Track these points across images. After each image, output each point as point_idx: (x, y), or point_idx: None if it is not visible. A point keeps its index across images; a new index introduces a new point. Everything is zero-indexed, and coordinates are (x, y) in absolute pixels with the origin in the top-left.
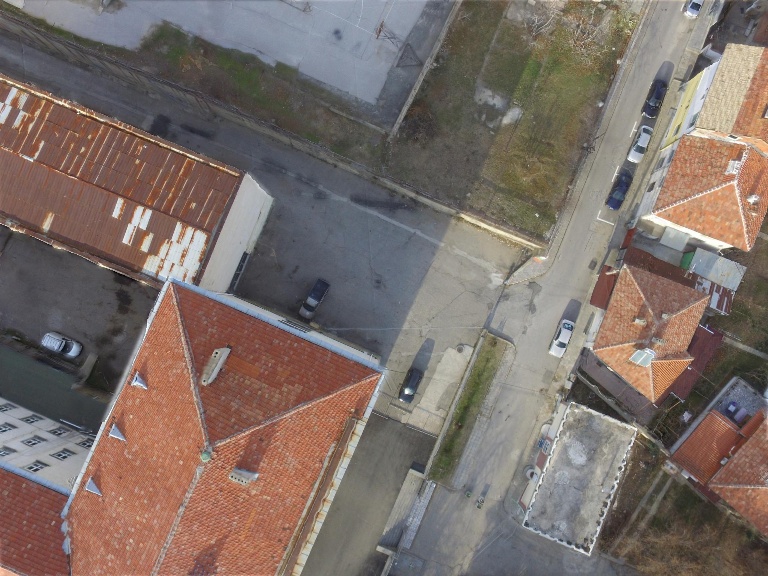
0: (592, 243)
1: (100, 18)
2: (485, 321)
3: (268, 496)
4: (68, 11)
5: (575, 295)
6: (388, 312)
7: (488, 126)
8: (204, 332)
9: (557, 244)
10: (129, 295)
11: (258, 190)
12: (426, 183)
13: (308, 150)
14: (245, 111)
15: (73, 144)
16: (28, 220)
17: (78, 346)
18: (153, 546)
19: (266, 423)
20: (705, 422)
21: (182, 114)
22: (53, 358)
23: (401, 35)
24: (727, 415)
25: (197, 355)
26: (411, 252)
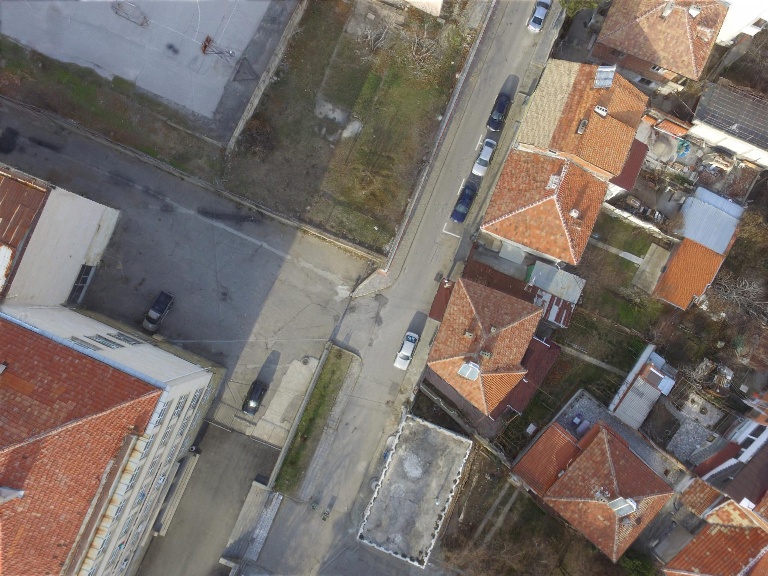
0: (438, 256)
1: None
2: (331, 333)
3: (38, 513)
4: None
5: (421, 307)
6: (234, 324)
7: (328, 139)
8: None
9: (403, 256)
10: None
11: (86, 204)
12: (265, 196)
13: (153, 163)
14: (83, 124)
15: None
16: None
17: None
18: None
19: (29, 441)
20: (546, 435)
21: (30, 127)
22: None
23: (238, 49)
24: (571, 427)
25: None
26: (257, 264)
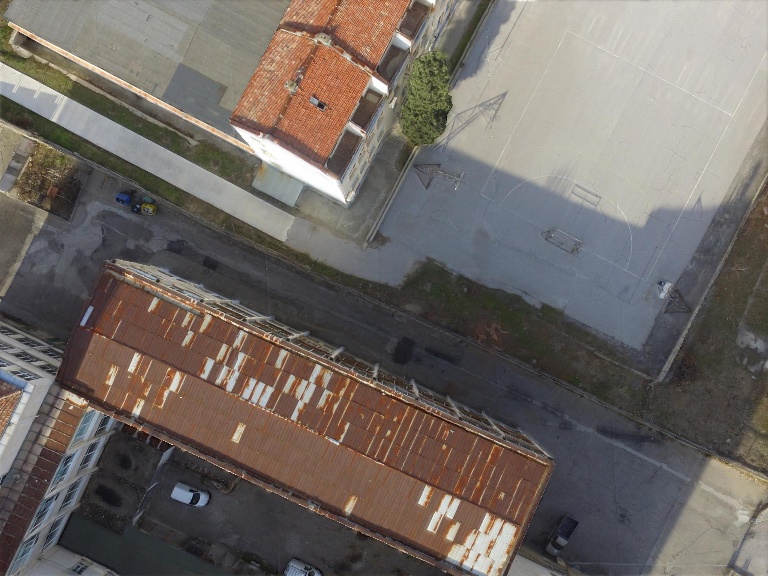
0: None
1: (364, 254)
2: (730, 559)
3: None
4: (331, 246)
5: None
6: (632, 547)
7: (750, 370)
8: None
9: None
10: None
11: None
12: (686, 427)
13: None
14: (507, 352)
15: (379, 427)
16: (330, 502)
17: (319, 575)
18: None
19: None
20: None
21: (427, 337)
22: None
23: (670, 281)
24: None
25: None
26: (657, 486)
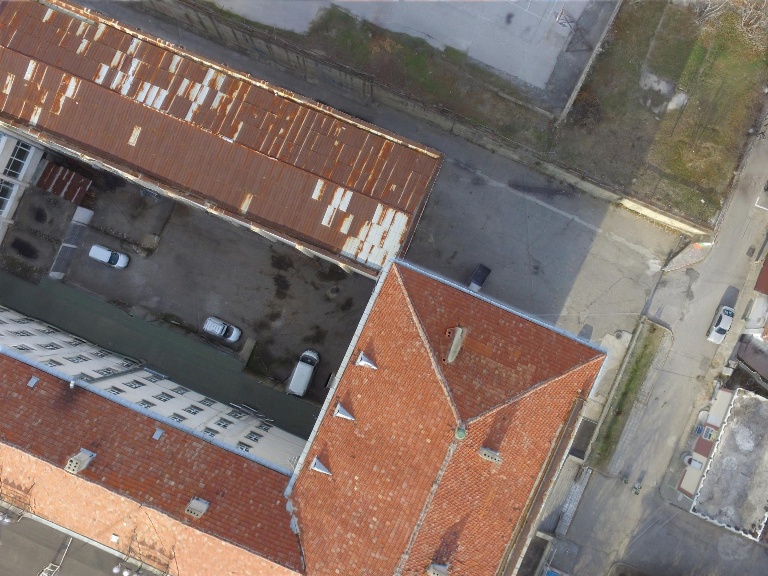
0: (750, 230)
1: (269, 1)
2: (643, 307)
3: (504, 475)
4: None
5: (733, 282)
6: (546, 298)
7: (653, 112)
8: (434, 312)
9: None
10: (287, 280)
11: None
12: (592, 168)
13: (469, 135)
14: None
15: (272, 125)
16: (226, 201)
17: (238, 331)
18: (403, 524)
19: (510, 402)
20: None
21: (339, 99)
22: (213, 343)
23: None
24: None
25: (432, 334)
26: (569, 238)
